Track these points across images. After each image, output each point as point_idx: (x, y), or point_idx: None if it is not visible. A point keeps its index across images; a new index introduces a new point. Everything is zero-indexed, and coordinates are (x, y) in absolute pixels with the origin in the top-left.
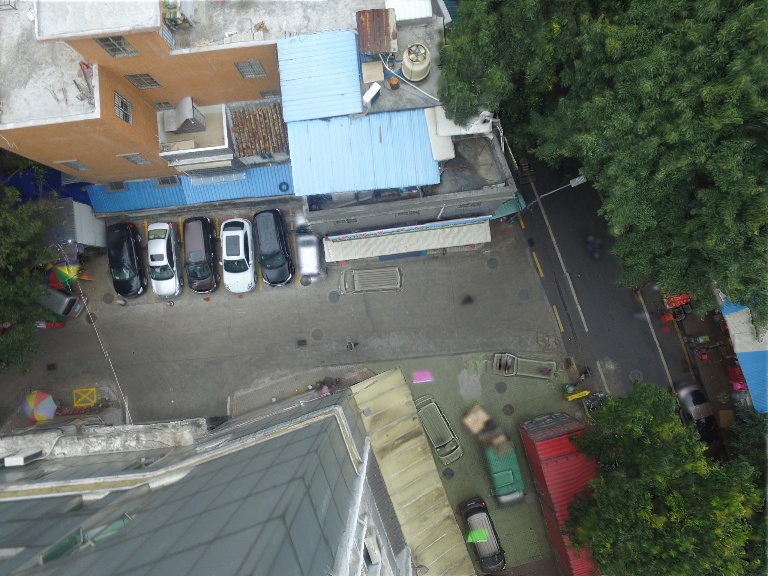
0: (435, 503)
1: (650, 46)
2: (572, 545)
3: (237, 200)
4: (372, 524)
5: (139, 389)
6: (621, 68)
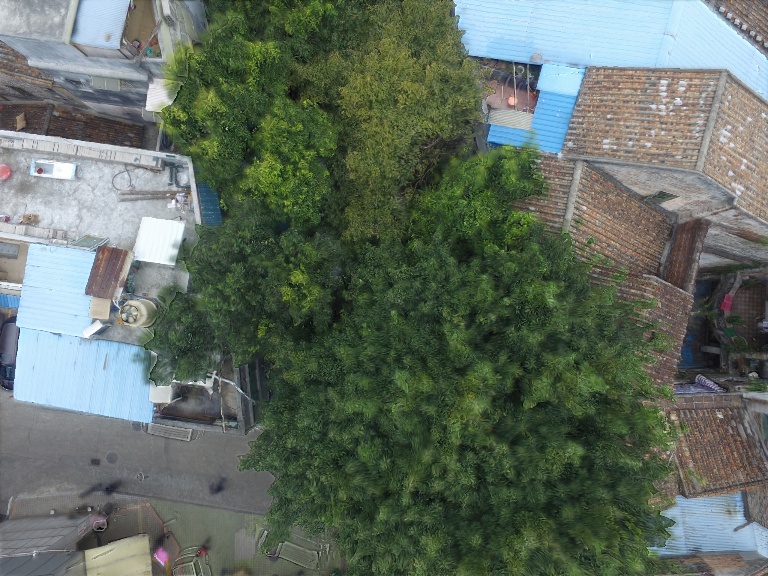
0: None
1: (335, 379)
2: None
3: None
4: None
5: None
6: (301, 394)
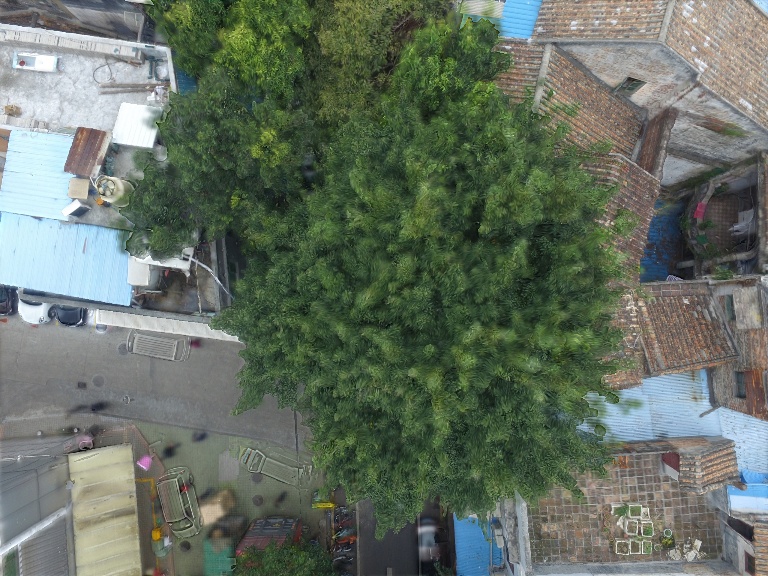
0: None
1: None
2: None
3: None
4: None
5: None
6: (272, 258)
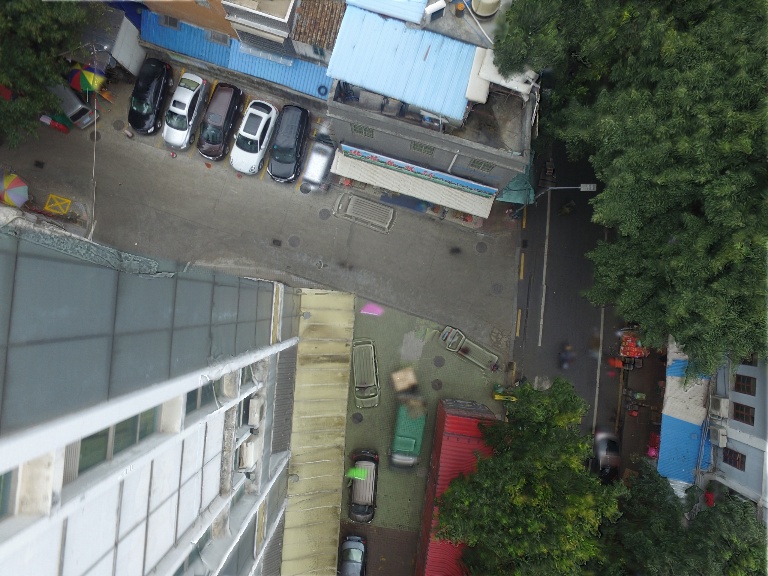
0: (332, 428)
1: (703, 66)
2: (438, 516)
3: (275, 84)
4: (264, 394)
5: (111, 219)
6: (668, 74)
